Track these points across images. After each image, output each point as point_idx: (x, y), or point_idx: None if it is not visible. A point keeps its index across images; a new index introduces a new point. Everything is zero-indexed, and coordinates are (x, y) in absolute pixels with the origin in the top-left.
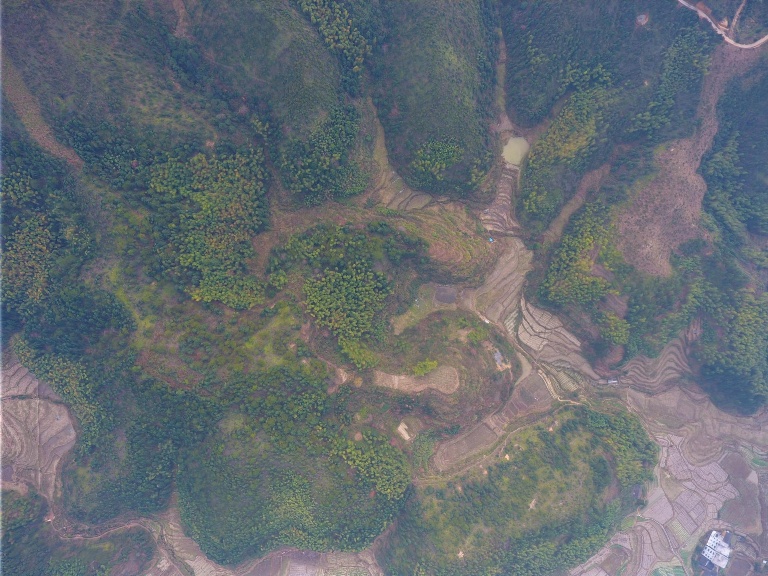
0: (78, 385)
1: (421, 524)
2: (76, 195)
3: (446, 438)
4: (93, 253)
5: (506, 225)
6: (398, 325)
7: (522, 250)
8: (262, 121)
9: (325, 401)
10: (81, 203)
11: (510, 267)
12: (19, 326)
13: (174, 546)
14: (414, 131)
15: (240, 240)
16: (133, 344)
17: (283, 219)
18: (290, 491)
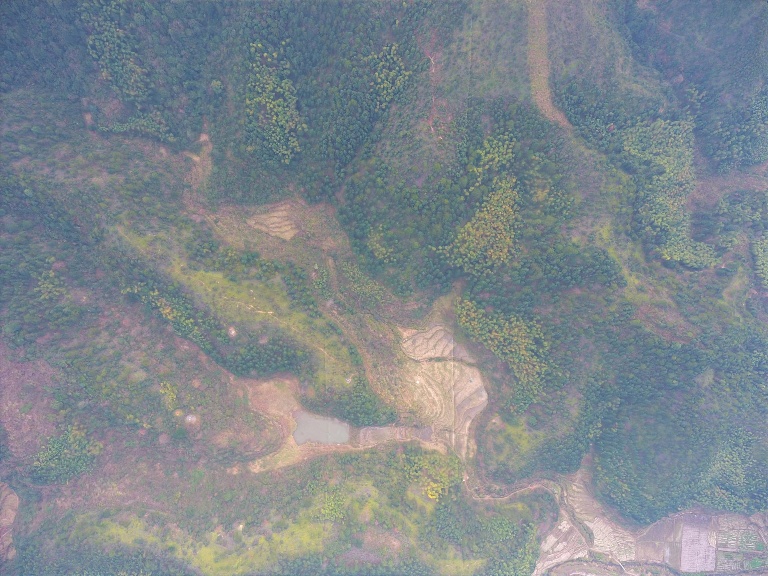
0: (529, 344)
1: None
2: (561, 157)
3: None
4: (574, 213)
5: None
6: None
7: None
8: (698, 90)
9: (767, 360)
10: (563, 165)
11: None
12: (450, 289)
13: (575, 507)
14: None
15: None
16: (629, 299)
17: None
18: (729, 449)
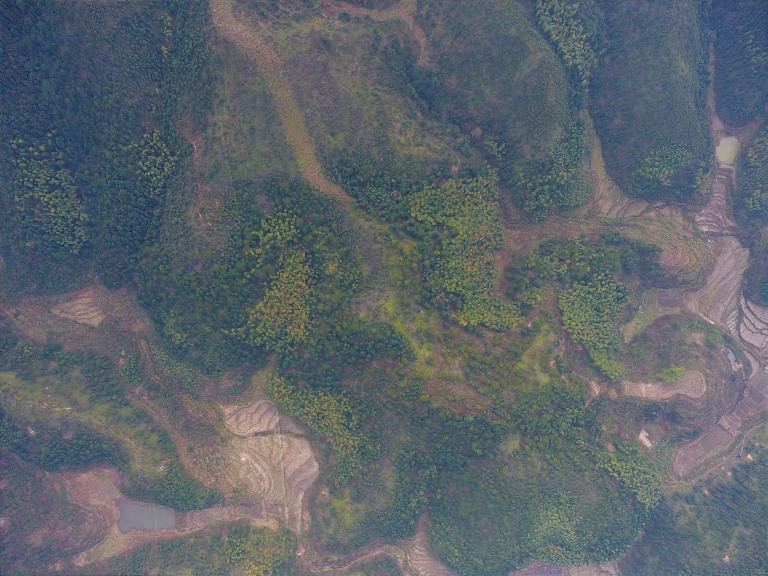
0: (339, 418)
1: (678, 531)
2: (343, 230)
3: (685, 442)
4: (362, 286)
5: (722, 225)
6: (627, 333)
7: (738, 248)
8: (497, 142)
9: (585, 415)
10: (347, 238)
11: (728, 266)
12: (265, 363)
13: (419, 570)
14: (642, 139)
15: (487, 261)
16: (417, 373)
17: (511, 237)
18: (554, 507)
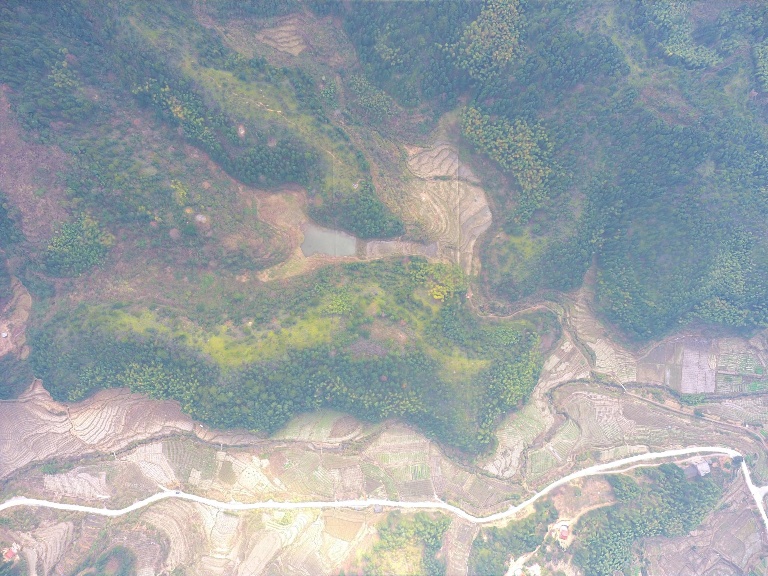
0: (533, 147)
1: None
2: None
3: None
4: (578, 6)
5: None
6: None
7: None
8: None
9: (767, 164)
10: None
11: None
12: (455, 103)
13: (577, 328)
14: None
15: None
16: None
17: (696, 7)
18: (729, 253)
